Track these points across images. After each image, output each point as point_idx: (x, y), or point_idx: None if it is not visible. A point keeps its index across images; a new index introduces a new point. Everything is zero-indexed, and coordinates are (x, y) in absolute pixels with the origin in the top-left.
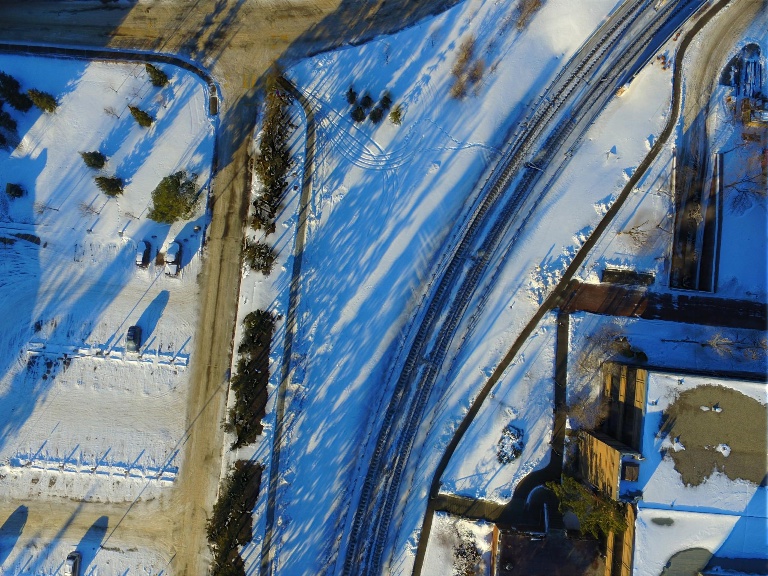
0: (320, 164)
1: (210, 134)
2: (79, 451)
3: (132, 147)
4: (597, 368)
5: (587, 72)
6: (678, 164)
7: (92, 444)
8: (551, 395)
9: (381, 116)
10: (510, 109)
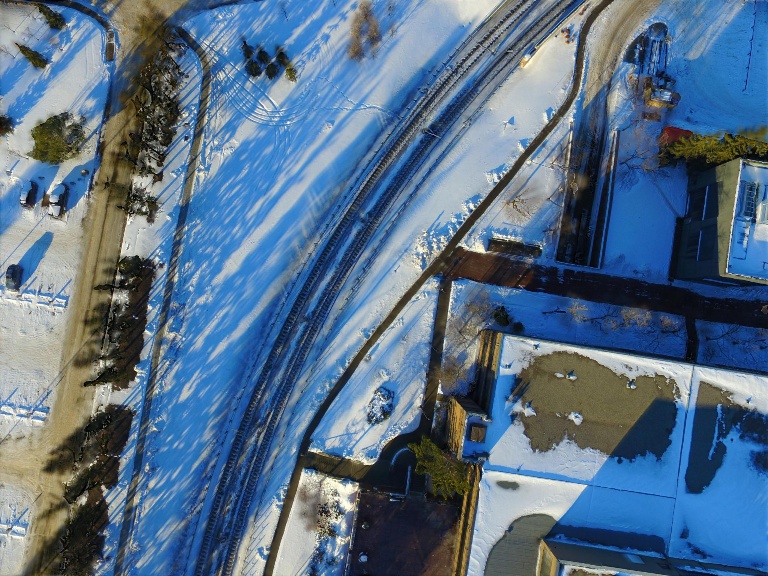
0: (213, 116)
1: (105, 79)
2: None
3: (25, 87)
4: (475, 336)
5: (493, 42)
6: (574, 138)
7: None
8: (426, 360)
9: (276, 71)
10: (410, 74)
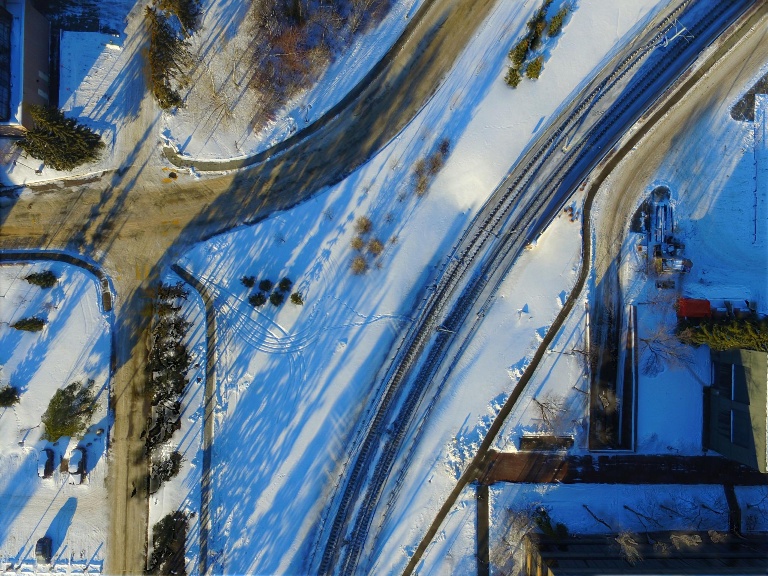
0: (223, 352)
1: (106, 332)
2: None
3: (25, 353)
4: (519, 541)
5: (495, 225)
6: None
7: None
8: (473, 573)
9: (281, 299)
10: (417, 274)
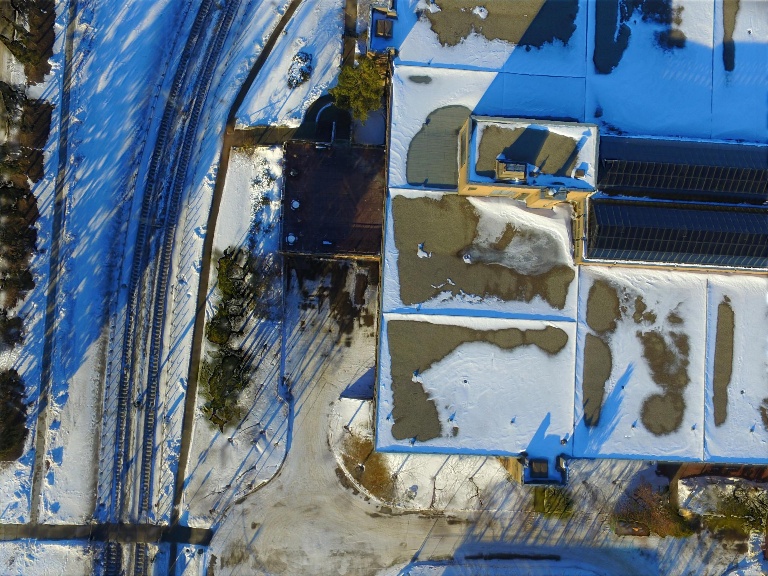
0: None
1: None
2: None
3: None
4: None
5: None
6: None
7: None
8: (340, 23)
9: None
10: None
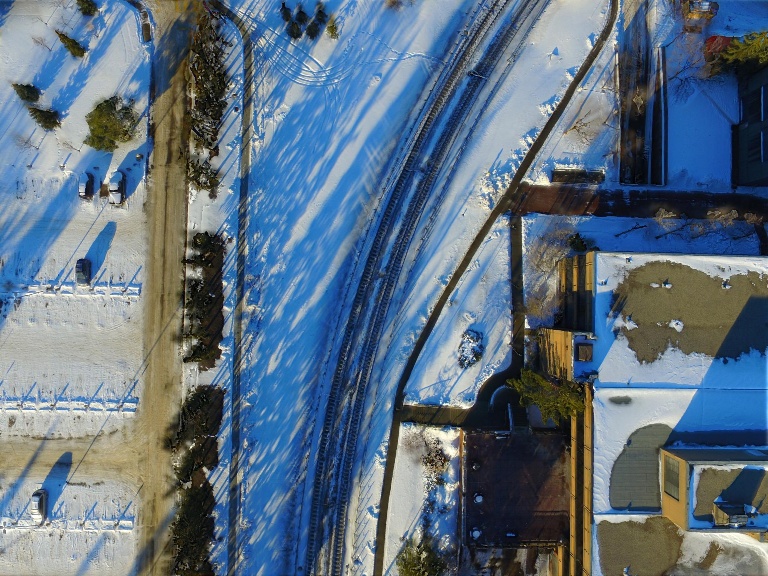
0: (260, 84)
1: (145, 61)
2: (37, 388)
3: (66, 79)
4: (552, 267)
5: None
6: (620, 60)
7: (49, 380)
8: (508, 297)
9: (317, 30)
10: (449, 18)
